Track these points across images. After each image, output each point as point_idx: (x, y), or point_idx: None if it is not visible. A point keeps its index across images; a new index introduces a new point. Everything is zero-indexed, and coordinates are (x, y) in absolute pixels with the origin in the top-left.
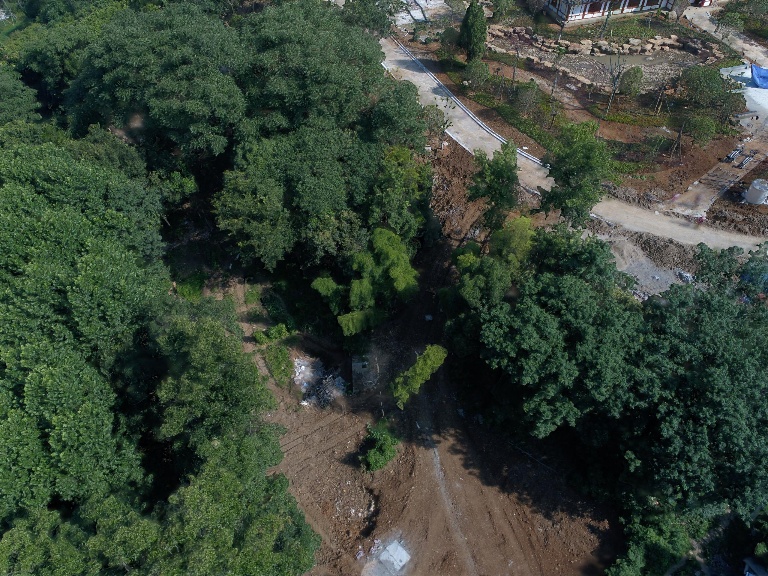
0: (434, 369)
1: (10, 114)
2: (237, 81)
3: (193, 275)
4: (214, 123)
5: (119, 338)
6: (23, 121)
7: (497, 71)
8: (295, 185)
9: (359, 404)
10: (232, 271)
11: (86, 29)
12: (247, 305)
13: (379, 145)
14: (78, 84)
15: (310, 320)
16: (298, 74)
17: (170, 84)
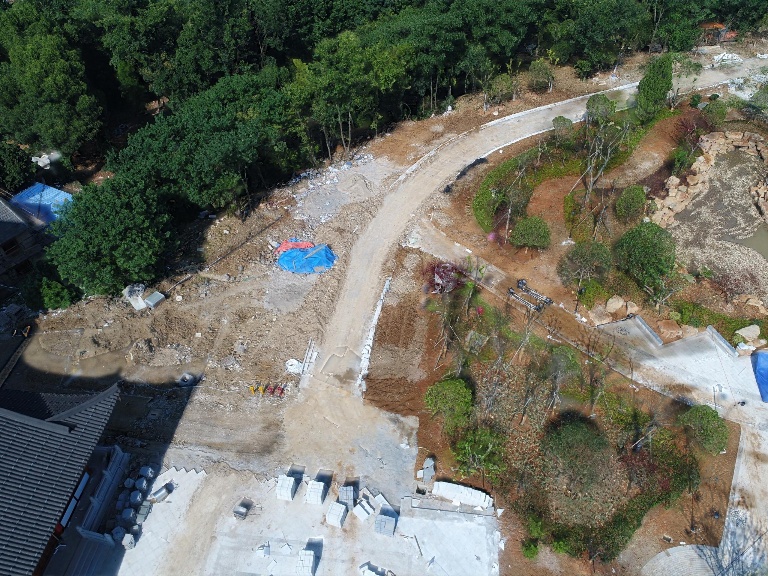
0: None
1: None
2: None
3: None
4: None
5: None
6: None
7: None
8: None
9: None
10: None
11: None
12: None
13: None
14: None
15: None
16: None
17: None
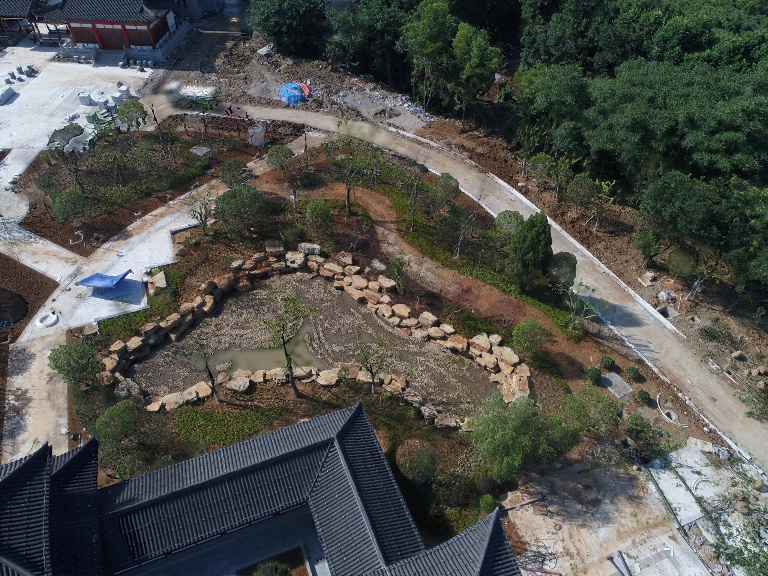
0: None
1: None
2: None
3: None
4: None
5: None
6: None
7: None
8: None
9: None
10: None
11: None
12: None
13: None
14: None
15: None
16: None
17: None
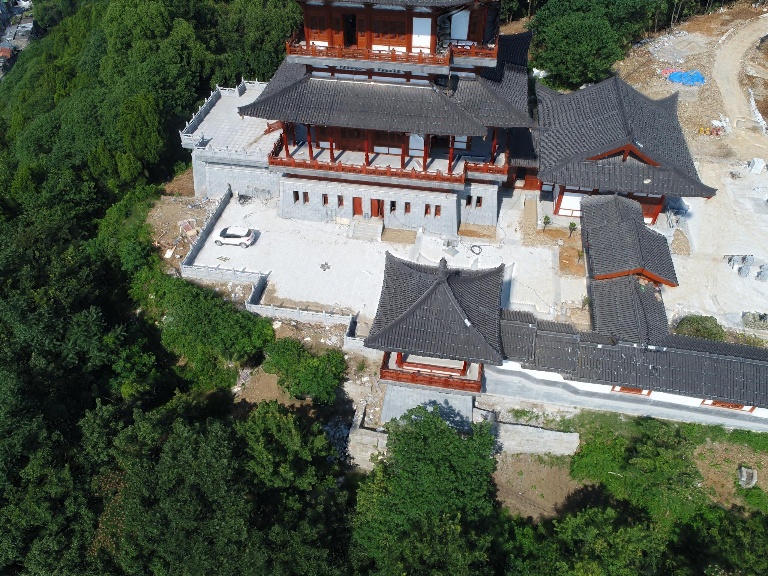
0: None
1: None
2: None
3: None
4: None
5: None
6: None
7: None
8: None
9: None
10: None
11: None
12: None
13: None
14: None
15: None
16: None
17: None
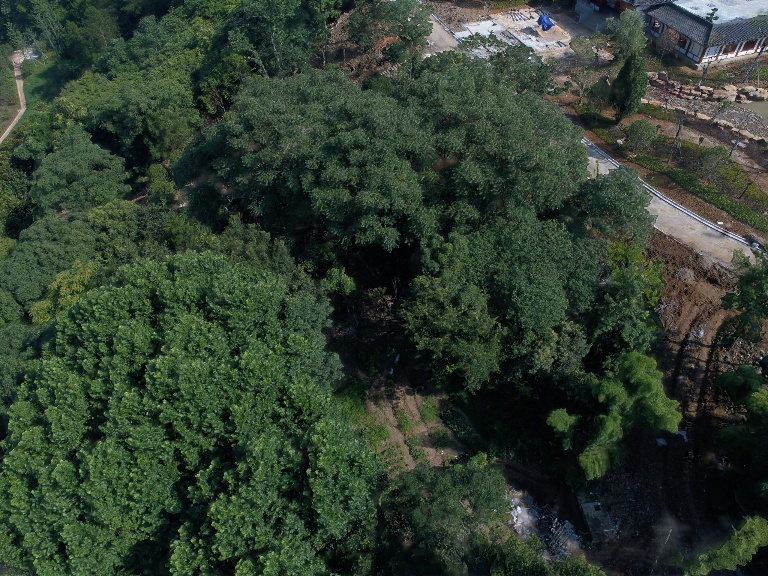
0: (756, 547)
1: (100, 188)
2: (411, 164)
3: (350, 384)
4: (378, 211)
5: (361, 524)
6: (126, 201)
7: (657, 128)
8: (507, 294)
9: (604, 560)
10: (395, 378)
11: (169, 85)
12: (426, 423)
13: (599, 241)
14: (190, 158)
15: (509, 443)
16: (494, 158)
17: (340, 172)
